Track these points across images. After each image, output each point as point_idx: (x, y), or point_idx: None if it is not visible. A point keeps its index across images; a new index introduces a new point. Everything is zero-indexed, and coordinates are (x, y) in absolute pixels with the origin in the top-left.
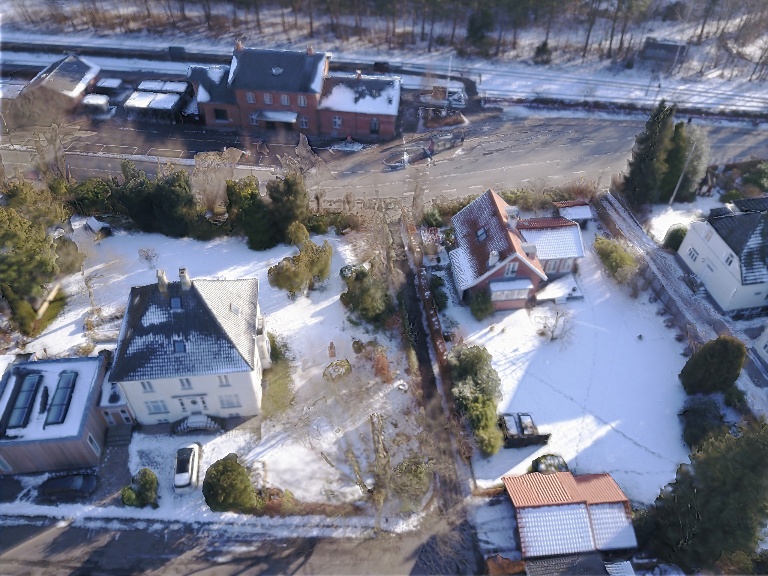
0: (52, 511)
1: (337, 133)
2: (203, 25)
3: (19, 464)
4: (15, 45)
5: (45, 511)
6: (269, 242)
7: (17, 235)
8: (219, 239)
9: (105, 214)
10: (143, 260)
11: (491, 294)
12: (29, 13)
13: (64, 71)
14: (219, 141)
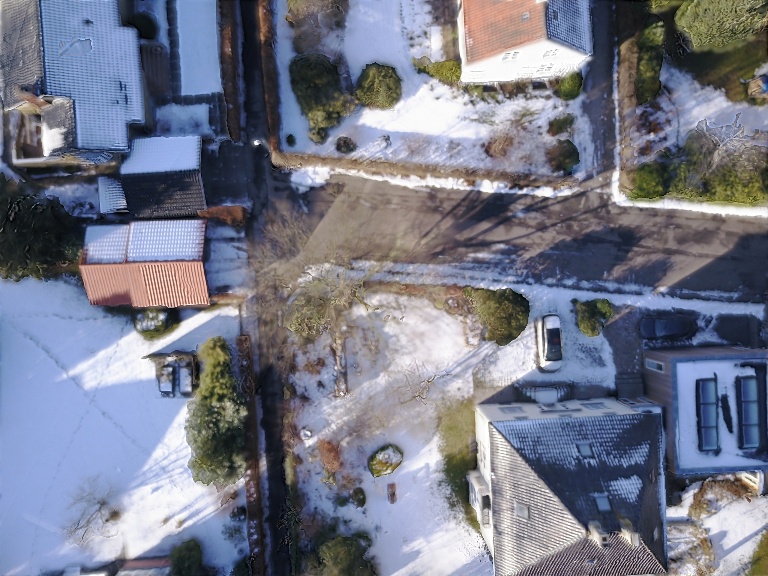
0: (676, 303)
1: None
2: None
3: None
4: None
5: (683, 303)
6: None
7: None
8: None
9: None
10: None
11: (168, 575)
12: None
13: None
14: None
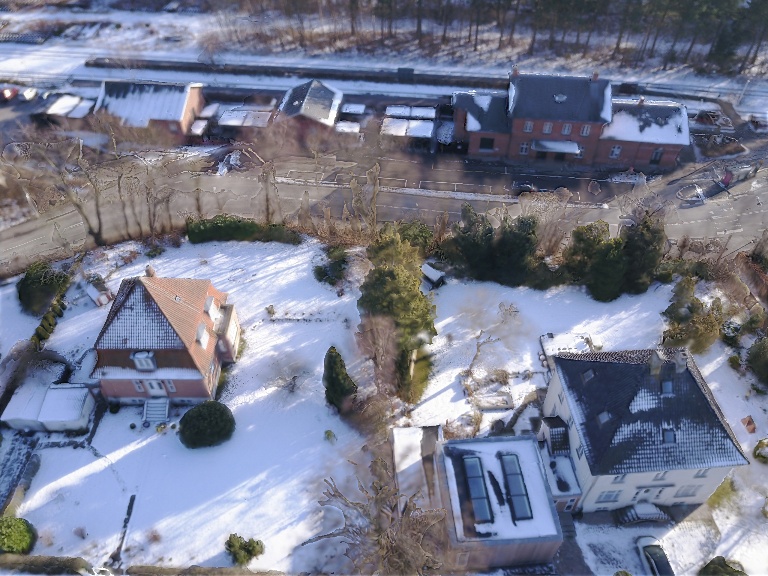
0: None
1: (612, 163)
2: (412, 43)
3: (477, 560)
4: (235, 68)
5: None
6: (616, 293)
7: (416, 295)
8: (554, 288)
9: (428, 259)
10: (507, 316)
11: None
12: (238, 33)
13: (314, 98)
14: (488, 172)
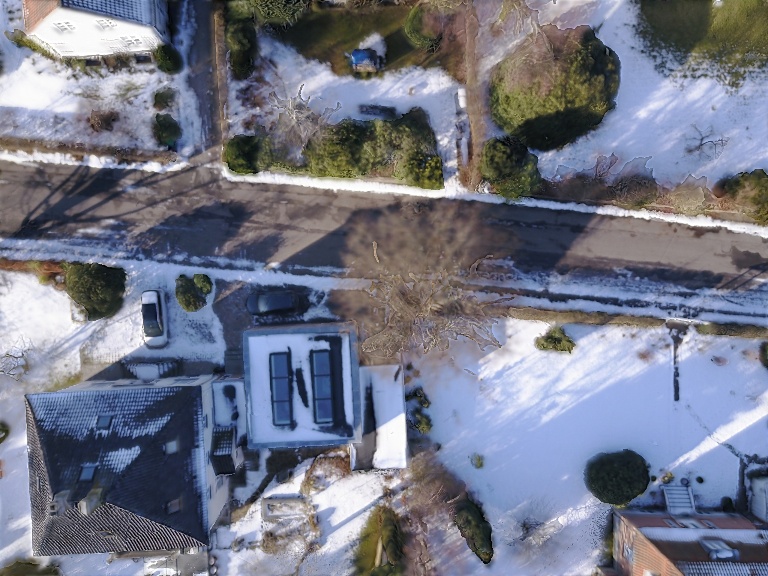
0: (288, 279)
1: None
2: None
3: None
4: None
5: (295, 279)
6: None
7: None
8: None
9: None
10: None
11: None
12: None
13: None
14: None
